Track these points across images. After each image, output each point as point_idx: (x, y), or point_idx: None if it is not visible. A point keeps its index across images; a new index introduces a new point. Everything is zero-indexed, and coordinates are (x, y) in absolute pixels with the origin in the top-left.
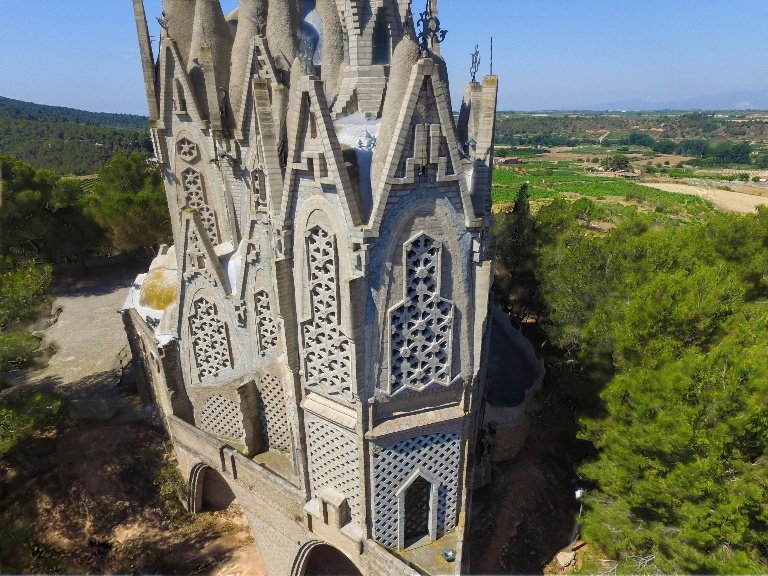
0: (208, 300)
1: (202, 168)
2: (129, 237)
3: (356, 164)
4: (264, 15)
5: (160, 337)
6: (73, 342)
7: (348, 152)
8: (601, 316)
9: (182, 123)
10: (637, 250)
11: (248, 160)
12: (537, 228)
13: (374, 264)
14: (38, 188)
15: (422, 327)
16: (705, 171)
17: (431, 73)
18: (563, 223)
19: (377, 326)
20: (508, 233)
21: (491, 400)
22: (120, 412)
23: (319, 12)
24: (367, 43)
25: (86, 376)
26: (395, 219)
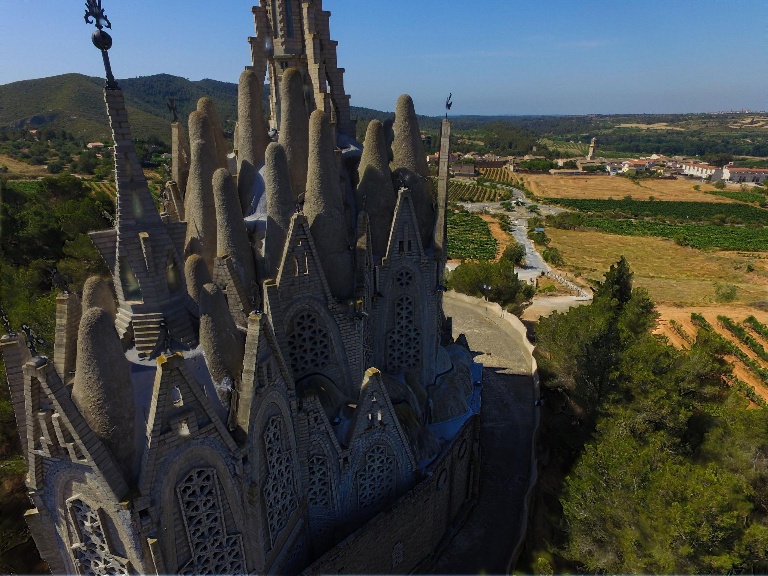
0: None
1: None
2: None
3: None
4: None
5: None
6: None
7: None
8: None
9: None
10: (665, 492)
11: None
12: (613, 379)
13: (50, 506)
14: None
15: (103, 571)
16: None
17: (36, 375)
18: (646, 386)
19: (68, 553)
20: (585, 369)
21: None
22: None
23: None
24: (118, 282)
25: None
26: (55, 478)
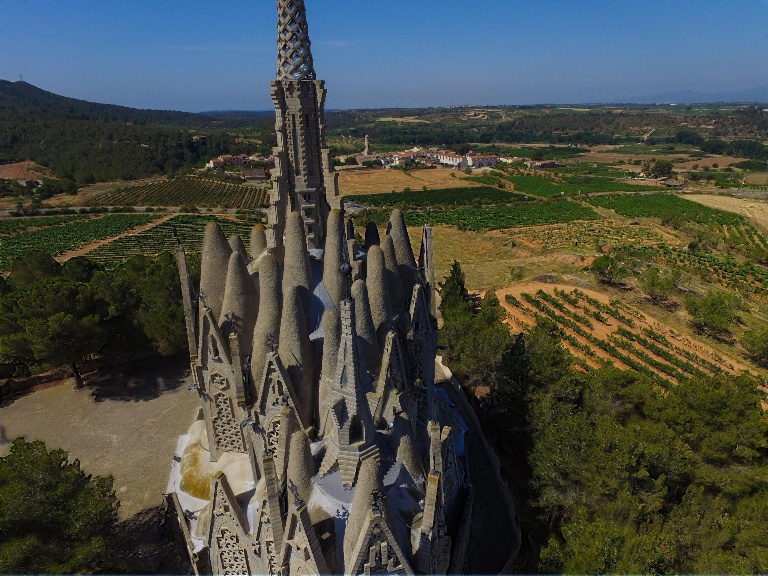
0: (232, 532)
1: (231, 393)
2: (172, 345)
3: (334, 533)
4: (279, 310)
5: (195, 541)
6: (125, 467)
7: (328, 522)
8: (555, 545)
9: (215, 363)
10: (606, 445)
11: (265, 424)
12: (530, 376)
13: None
14: (97, 310)
15: None
16: (746, 200)
17: (380, 522)
18: (553, 376)
19: None
20: (505, 372)
21: (470, 571)
22: (163, 564)
23: (325, 284)
24: (345, 433)
25: (136, 514)
26: None
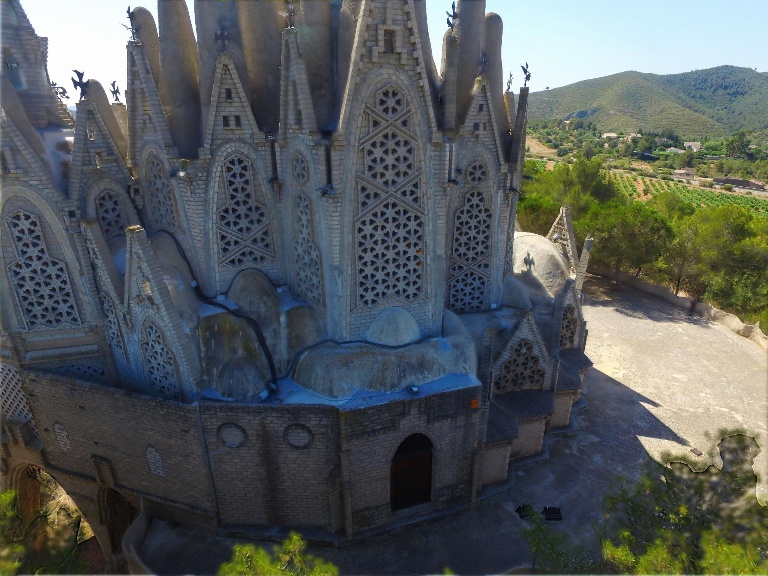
0: None
1: None
2: None
3: None
4: None
5: None
6: None
7: None
8: None
9: None
10: None
11: None
12: None
13: None
14: None
15: None
16: None
17: None
18: None
19: None
20: None
21: (184, 536)
22: None
23: None
24: None
25: None
26: None
